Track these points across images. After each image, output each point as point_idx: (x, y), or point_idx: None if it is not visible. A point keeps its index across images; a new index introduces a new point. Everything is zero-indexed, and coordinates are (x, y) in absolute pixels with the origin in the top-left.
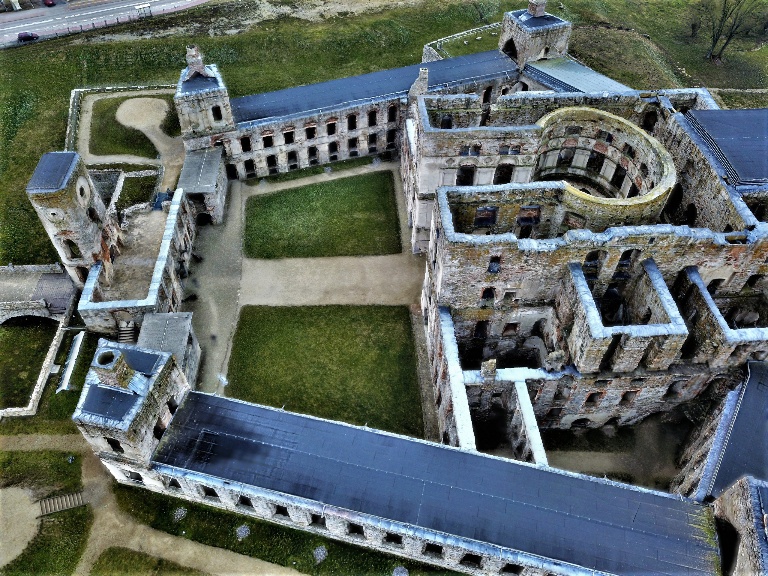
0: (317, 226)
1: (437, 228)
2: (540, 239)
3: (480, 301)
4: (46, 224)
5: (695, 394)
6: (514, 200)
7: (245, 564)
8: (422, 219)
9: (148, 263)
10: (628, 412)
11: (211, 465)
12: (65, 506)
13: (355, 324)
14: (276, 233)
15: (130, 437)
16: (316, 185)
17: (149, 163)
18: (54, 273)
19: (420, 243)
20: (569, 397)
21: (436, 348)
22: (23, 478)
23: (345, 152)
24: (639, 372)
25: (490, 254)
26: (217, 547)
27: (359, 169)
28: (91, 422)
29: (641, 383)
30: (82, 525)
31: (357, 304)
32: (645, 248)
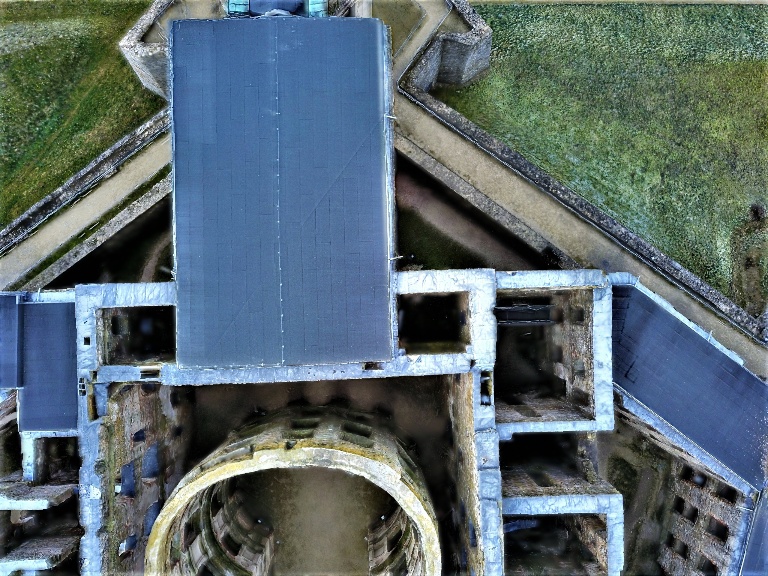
0: None
1: None
2: None
3: None
4: None
5: None
6: None
7: None
8: None
9: None
10: None
11: None
12: None
13: None
14: None
15: None
16: None
17: None
18: None
19: None
20: None
21: None
22: None
23: None
24: None
25: None
26: None
27: None
28: None
29: None
30: None
31: None
32: None
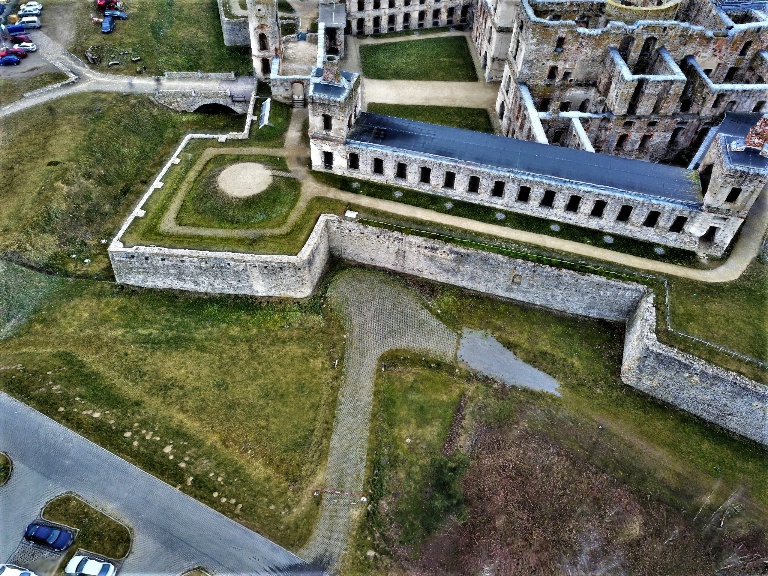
0: (414, 64)
1: (520, 26)
2: (591, 29)
3: (546, 80)
4: (252, 18)
5: (689, 142)
6: (572, 10)
7: (403, 207)
8: (497, 50)
9: (304, 67)
10: (644, 158)
11: (385, 141)
12: (284, 175)
13: (450, 116)
14: (385, 66)
15: (343, 109)
16: (409, 41)
17: (288, 16)
18: (229, 80)
19: (493, 72)
20: (606, 138)
21: (514, 115)
22: (254, 161)
23: (430, 21)
24: (653, 116)
25: (558, 35)
26: (383, 199)
27: (440, 34)
28: (320, 98)
29: (654, 127)
30: (295, 186)
31: (450, 106)
32: (660, 36)
